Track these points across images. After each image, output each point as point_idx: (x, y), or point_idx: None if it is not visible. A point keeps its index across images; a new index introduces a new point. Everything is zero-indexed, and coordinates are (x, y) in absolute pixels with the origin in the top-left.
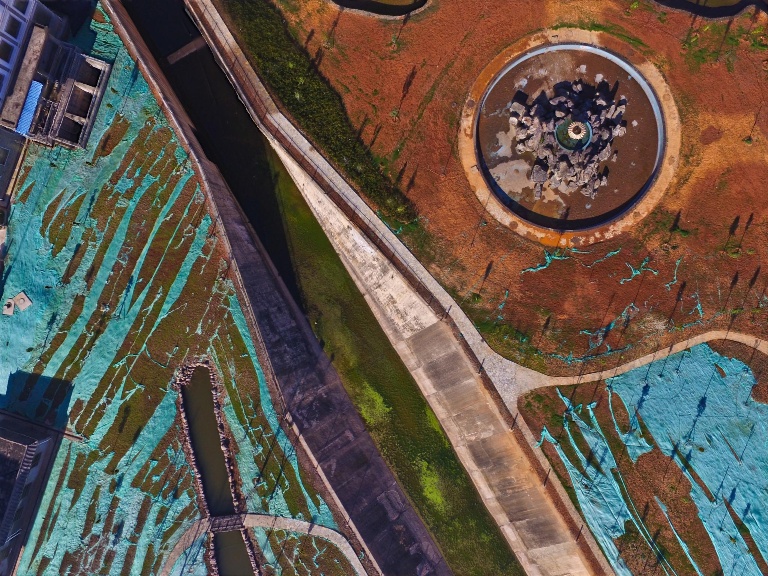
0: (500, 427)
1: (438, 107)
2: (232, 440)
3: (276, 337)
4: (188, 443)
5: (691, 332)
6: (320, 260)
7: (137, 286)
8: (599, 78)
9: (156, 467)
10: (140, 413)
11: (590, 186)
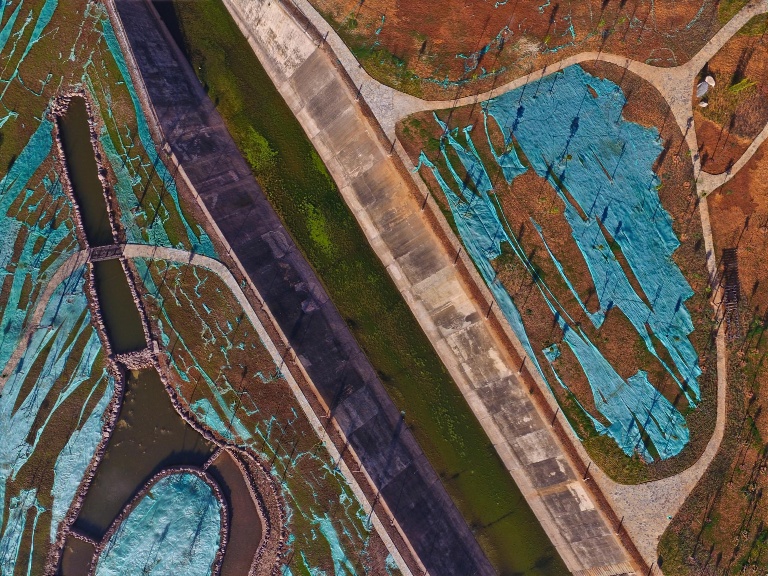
0: (379, 154)
1: None
2: (110, 170)
3: (154, 69)
4: (65, 174)
5: (564, 53)
6: (203, 4)
7: (6, 9)
8: None
9: (32, 197)
10: (14, 141)
11: None
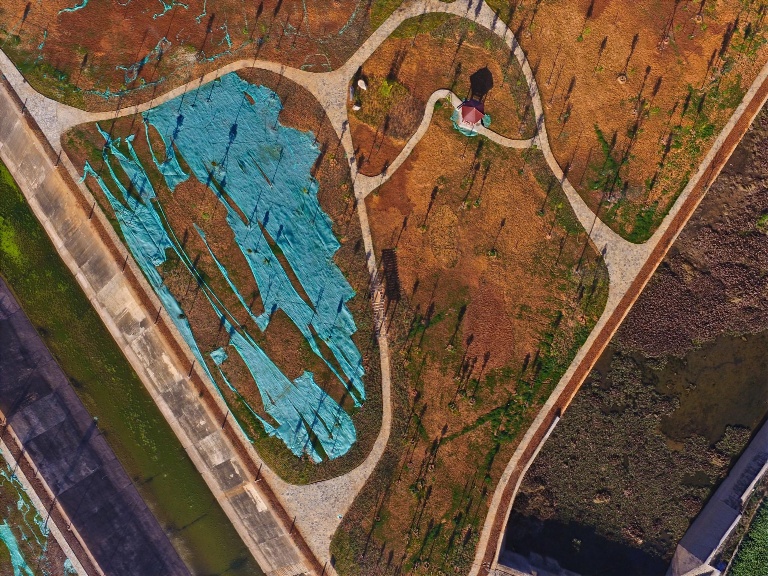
0: (47, 166)
1: None
2: None
3: None
4: None
5: (220, 62)
6: None
7: None
8: None
9: None
10: None
11: None
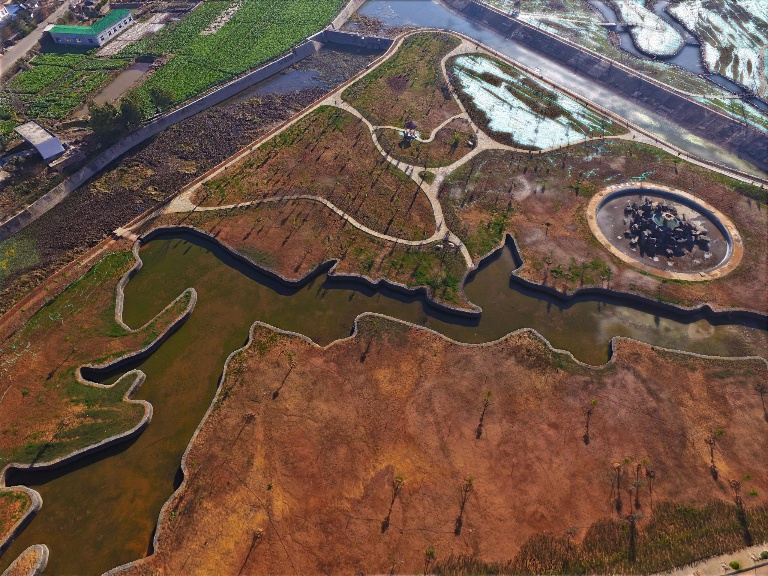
0: None
1: (760, 237)
2: (767, 116)
3: None
4: None
5: None
6: None
7: None
8: (656, 259)
9: None
10: None
11: (637, 204)
